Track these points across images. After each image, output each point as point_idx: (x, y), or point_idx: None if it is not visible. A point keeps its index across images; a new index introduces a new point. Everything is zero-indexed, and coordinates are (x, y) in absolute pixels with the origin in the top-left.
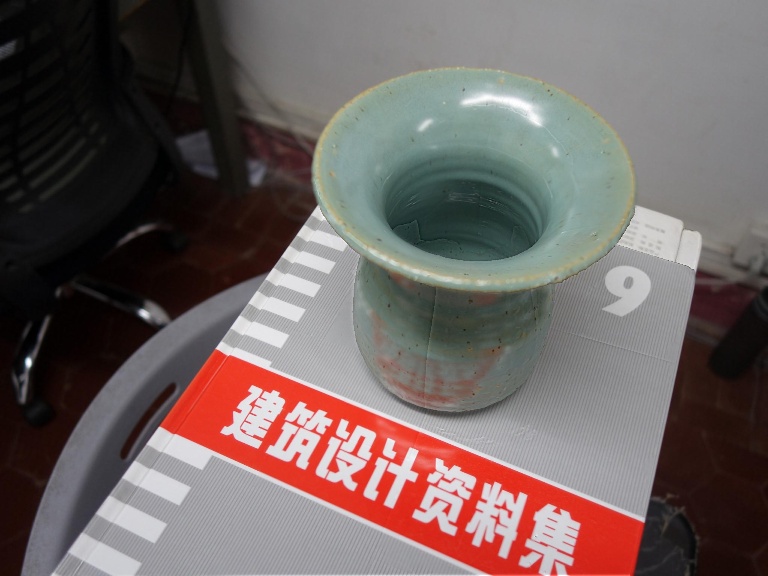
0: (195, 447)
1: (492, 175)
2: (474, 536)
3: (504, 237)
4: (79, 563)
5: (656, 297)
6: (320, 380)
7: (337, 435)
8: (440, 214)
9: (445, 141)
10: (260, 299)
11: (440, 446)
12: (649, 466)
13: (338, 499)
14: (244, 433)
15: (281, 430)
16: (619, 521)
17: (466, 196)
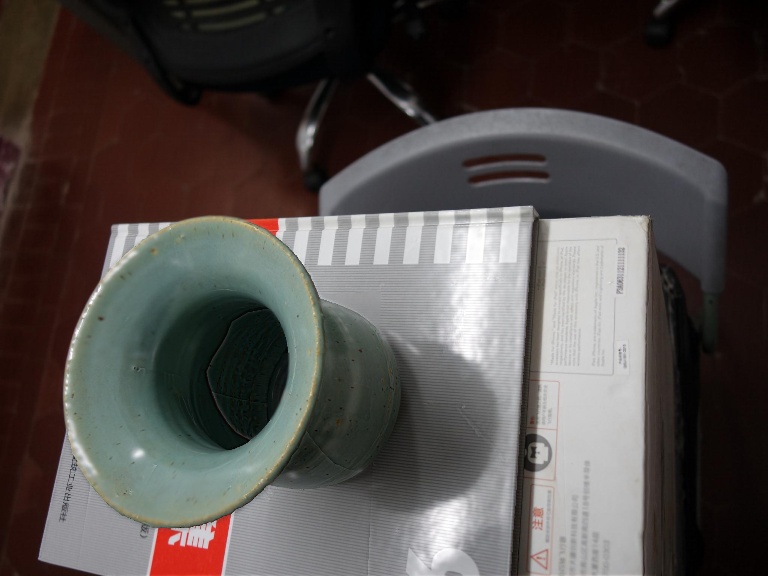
0: None
1: None
2: None
3: None
4: (136, 234)
5: None
6: None
7: None
8: None
9: None
10: (333, 223)
11: None
12: None
13: None
14: None
15: None
16: None
17: None
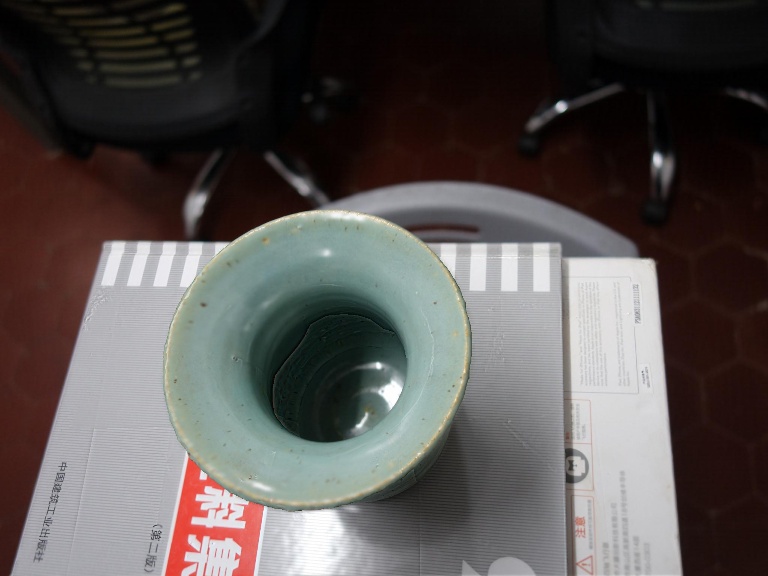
0: None
1: None
2: (203, 494)
3: None
4: (135, 252)
5: None
6: None
7: None
8: None
9: (397, 315)
10: None
11: None
12: None
13: None
14: None
15: None
16: None
17: None
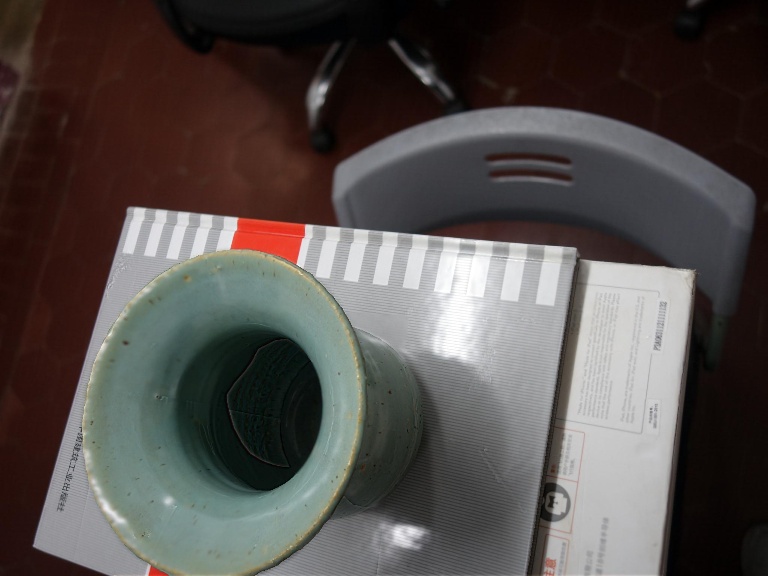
0: None
1: None
2: None
3: None
4: (153, 220)
5: None
6: None
7: None
8: None
9: None
10: (363, 237)
11: None
12: None
13: None
14: None
15: None
16: None
17: None
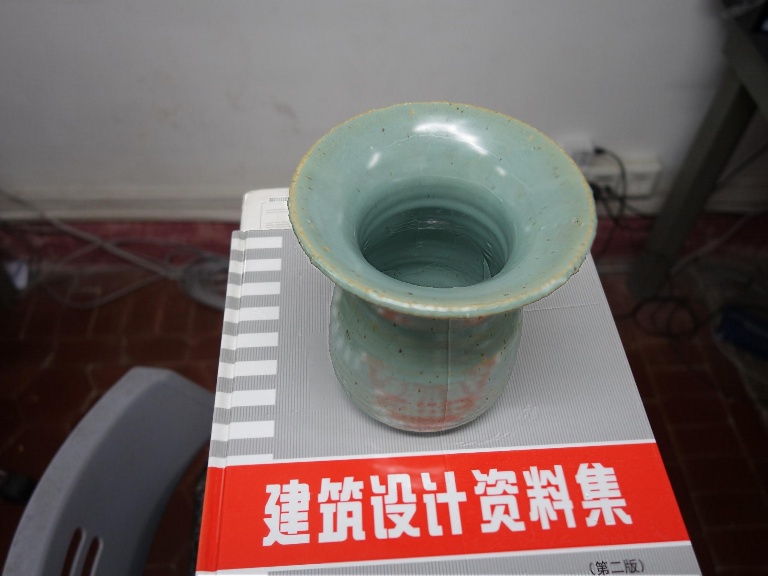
0: (246, 573)
1: (429, 199)
2: (541, 522)
3: (442, 250)
4: None
5: None
6: (329, 450)
7: (375, 493)
8: (380, 250)
9: (383, 182)
10: (224, 398)
11: (469, 458)
12: (634, 395)
13: (410, 551)
14: (287, 535)
15: (321, 514)
16: (638, 451)
17: (405, 225)
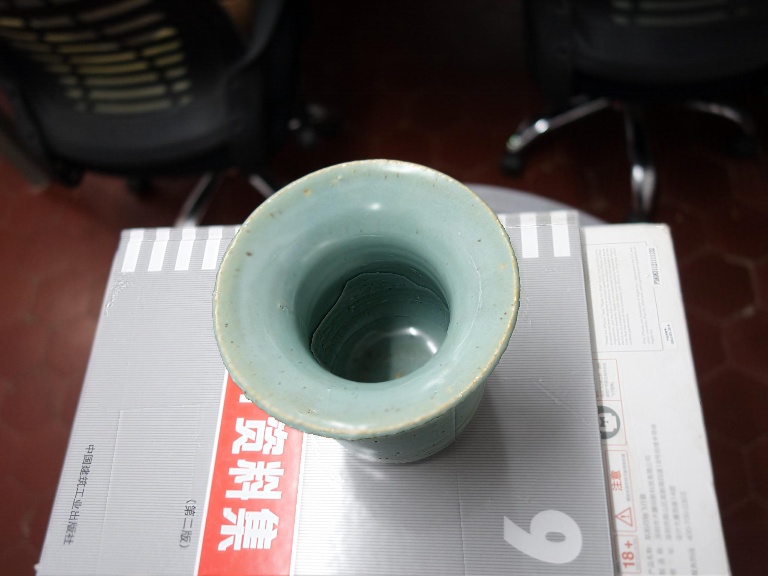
0: None
1: None
2: (236, 468)
3: None
4: (154, 239)
5: (549, 572)
6: None
7: None
8: None
9: (439, 259)
10: None
11: None
12: None
13: None
14: None
15: None
16: None
17: None
